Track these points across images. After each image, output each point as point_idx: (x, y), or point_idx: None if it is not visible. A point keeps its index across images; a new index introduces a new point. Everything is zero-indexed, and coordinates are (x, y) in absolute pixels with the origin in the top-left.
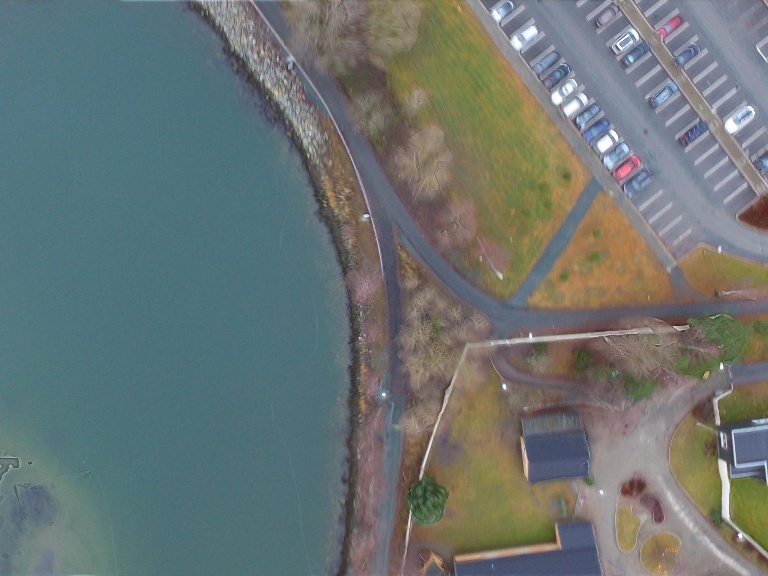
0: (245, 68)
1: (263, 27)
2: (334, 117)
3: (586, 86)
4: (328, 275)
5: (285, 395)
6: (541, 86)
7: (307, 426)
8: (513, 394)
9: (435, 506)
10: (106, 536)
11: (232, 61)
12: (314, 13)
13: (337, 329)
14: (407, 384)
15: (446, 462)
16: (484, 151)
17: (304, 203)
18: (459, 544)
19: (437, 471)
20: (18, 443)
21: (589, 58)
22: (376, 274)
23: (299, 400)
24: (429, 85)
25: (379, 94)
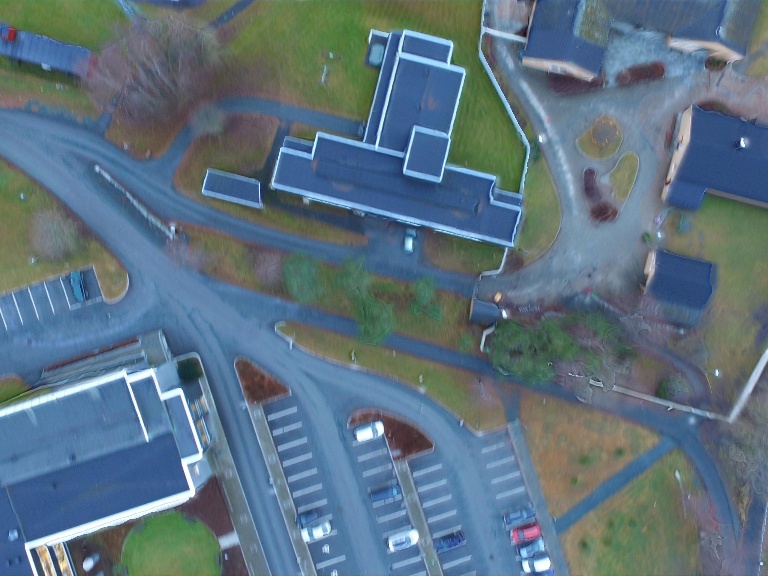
0: None
1: None
2: None
3: None
4: None
5: None
6: None
7: None
8: None
9: None
10: None
11: None
12: None
13: None
14: None
15: None
16: None
17: None
18: None
19: None
20: None
21: None
22: None
23: None
24: None
25: None
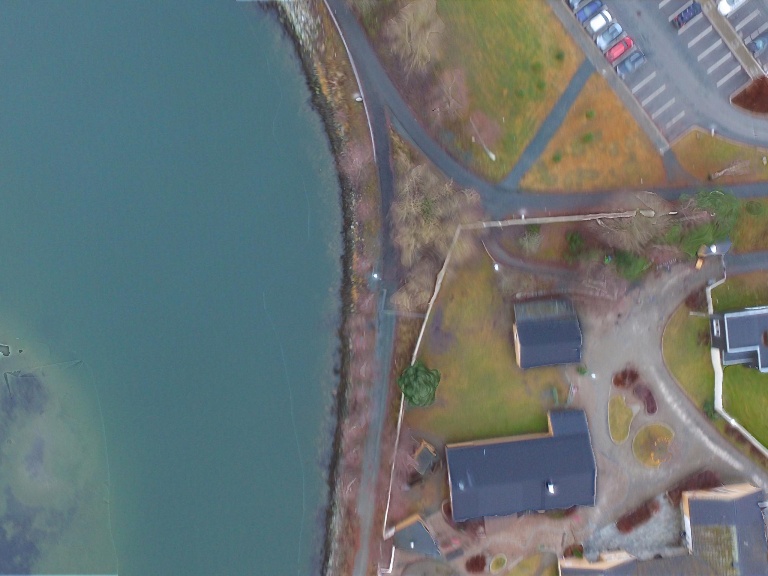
0: None
1: None
2: None
3: None
4: (320, 165)
5: (277, 285)
6: None
7: (299, 317)
8: (505, 276)
9: (426, 383)
10: (97, 426)
11: None
12: None
13: (329, 219)
14: (399, 271)
15: (438, 350)
16: (477, 30)
17: (297, 92)
18: (451, 433)
19: (429, 359)
20: (8, 330)
21: None
22: (368, 159)
23: (291, 290)
24: None
25: None
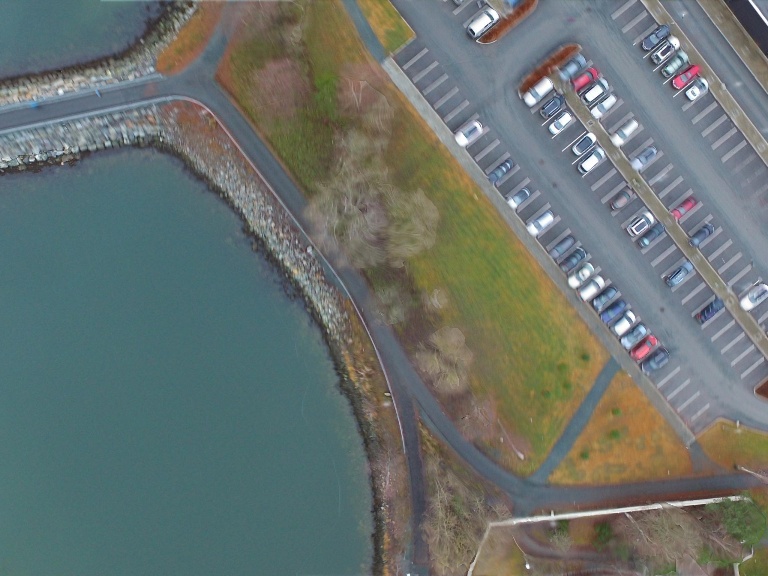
0: (264, 247)
1: (282, 212)
2: (353, 299)
3: (602, 268)
4: (350, 445)
5: (310, 564)
6: (558, 270)
7: None
8: (536, 571)
9: None
10: None
11: (251, 240)
12: (332, 201)
13: (360, 497)
14: None
15: None
16: (503, 335)
17: (325, 375)
18: None
19: None
20: None
21: (605, 240)
22: (398, 450)
23: (324, 568)
24: (447, 272)
25: (398, 279)
